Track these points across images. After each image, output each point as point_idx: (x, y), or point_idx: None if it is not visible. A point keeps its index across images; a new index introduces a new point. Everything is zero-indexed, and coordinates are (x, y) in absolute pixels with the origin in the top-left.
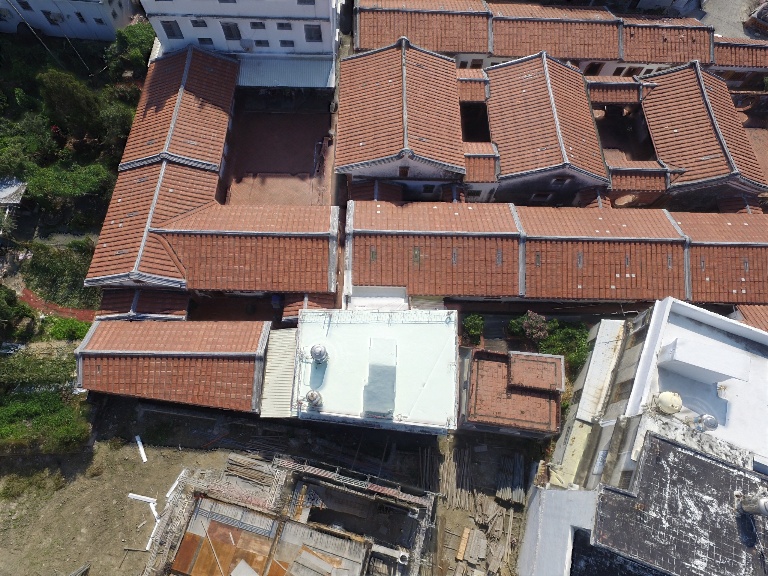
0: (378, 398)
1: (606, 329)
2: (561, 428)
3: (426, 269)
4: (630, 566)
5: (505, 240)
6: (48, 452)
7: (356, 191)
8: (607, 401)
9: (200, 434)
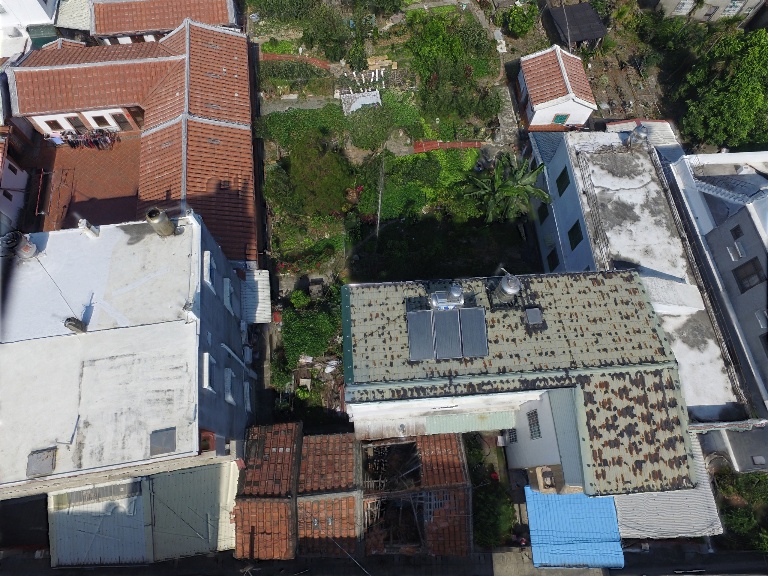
0: None
1: None
2: None
3: None
4: None
5: None
6: None
7: None
8: None
9: None
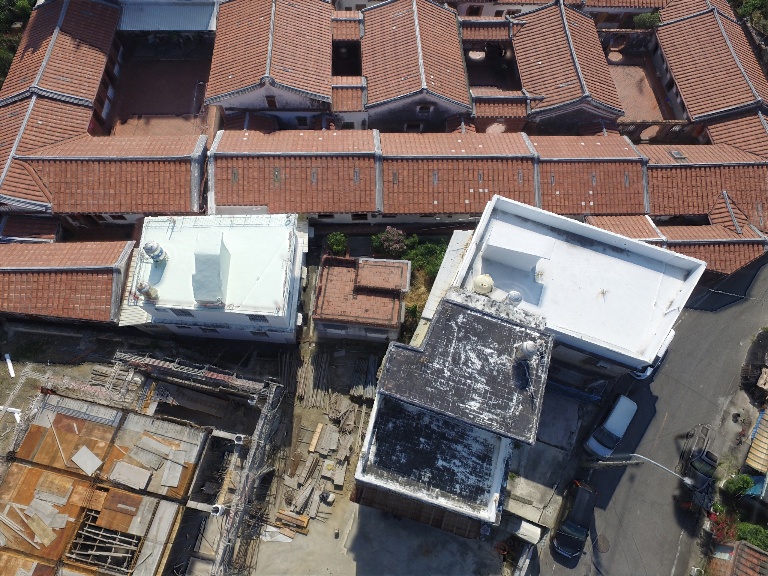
0: (206, 287)
1: (457, 238)
2: (414, 331)
3: (287, 188)
4: (434, 425)
5: (362, 159)
6: None
7: (229, 123)
8: None
9: (69, 351)
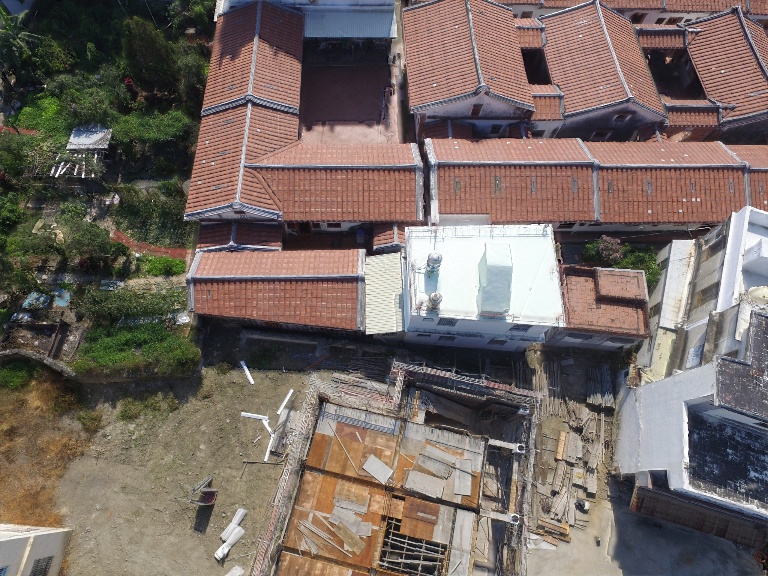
0: (495, 298)
1: (678, 248)
2: (641, 340)
3: (507, 197)
4: (738, 437)
5: (580, 168)
6: (163, 375)
7: (430, 131)
8: (689, 308)
9: (302, 358)
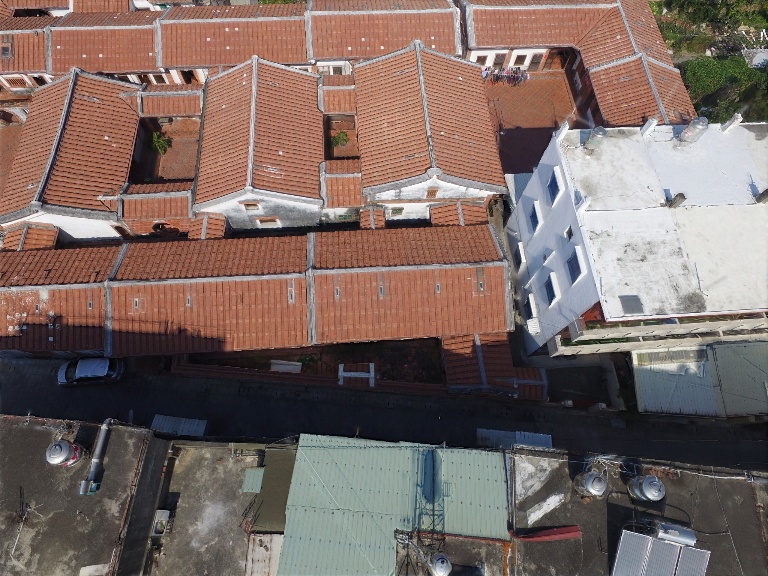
0: None
1: None
2: None
3: (388, 3)
4: None
5: None
6: None
7: None
8: None
9: None
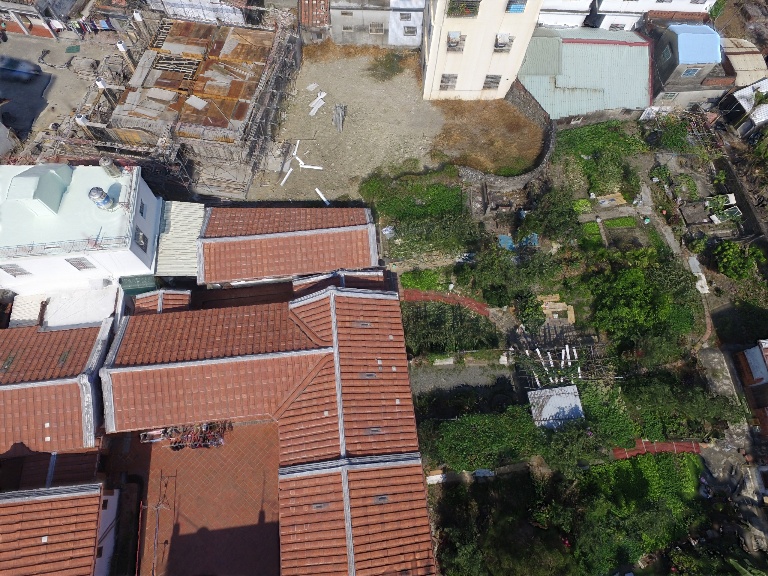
0: None
1: None
2: None
3: (3, 352)
4: None
5: None
6: None
7: (85, 473)
8: None
9: None
